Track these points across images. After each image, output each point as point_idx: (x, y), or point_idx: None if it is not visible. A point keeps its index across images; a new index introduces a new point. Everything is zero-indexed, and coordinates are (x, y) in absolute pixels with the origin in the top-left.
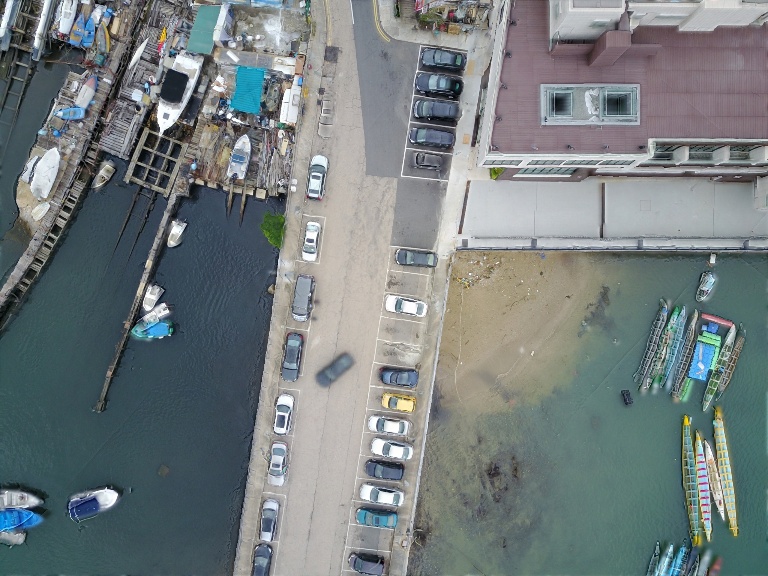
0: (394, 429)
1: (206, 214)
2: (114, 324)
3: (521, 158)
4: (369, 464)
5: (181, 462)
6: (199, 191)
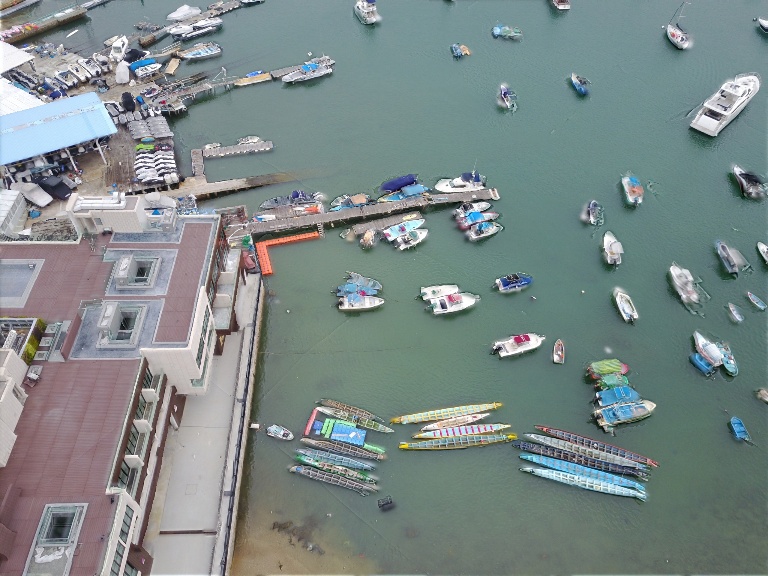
0: None
1: None
2: None
3: None
4: None
5: None
6: None
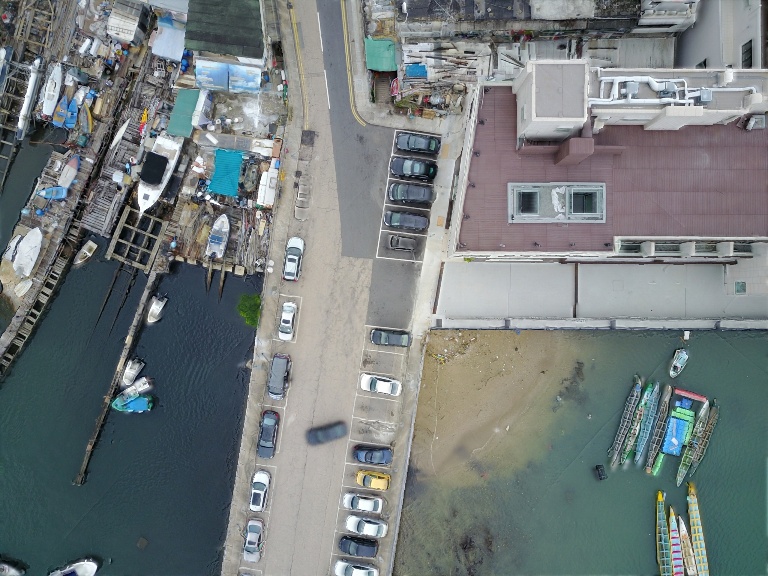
0: (369, 507)
1: (186, 288)
2: (95, 398)
3: (488, 255)
4: (344, 541)
5: (160, 534)
6: (180, 265)
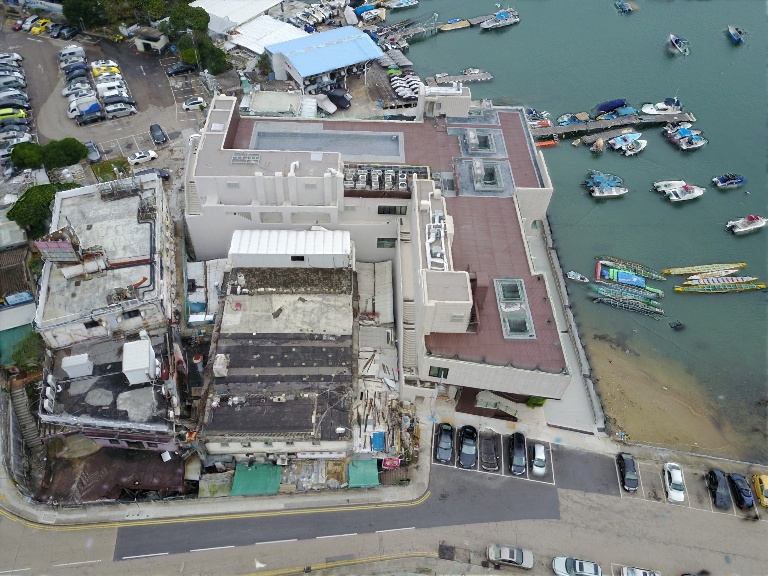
0: None
1: None
2: None
3: None
4: None
5: None
6: None
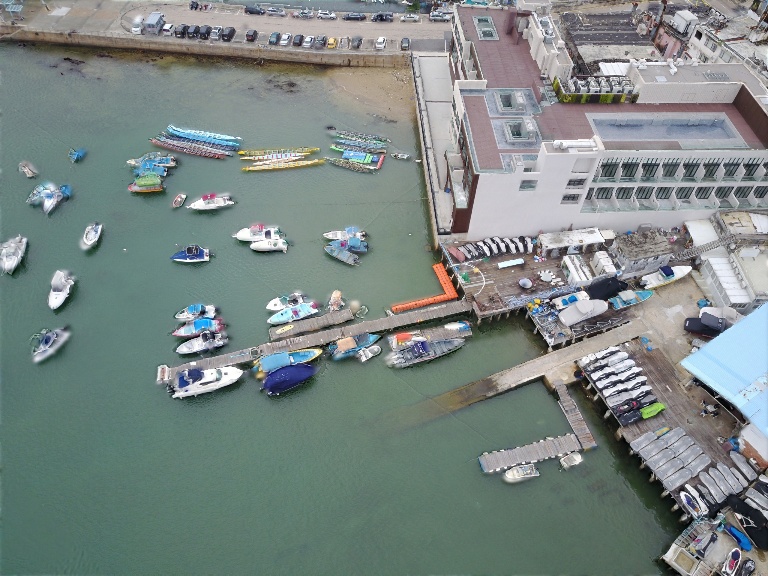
0: (319, 38)
1: None
2: None
3: None
4: None
5: (303, 7)
6: None
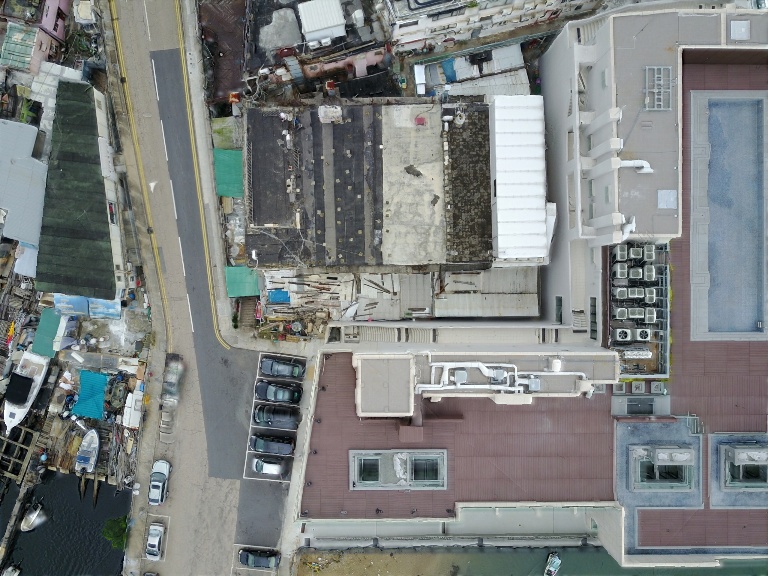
0: None
1: (62, 492)
2: None
3: None
4: None
5: None
6: None
